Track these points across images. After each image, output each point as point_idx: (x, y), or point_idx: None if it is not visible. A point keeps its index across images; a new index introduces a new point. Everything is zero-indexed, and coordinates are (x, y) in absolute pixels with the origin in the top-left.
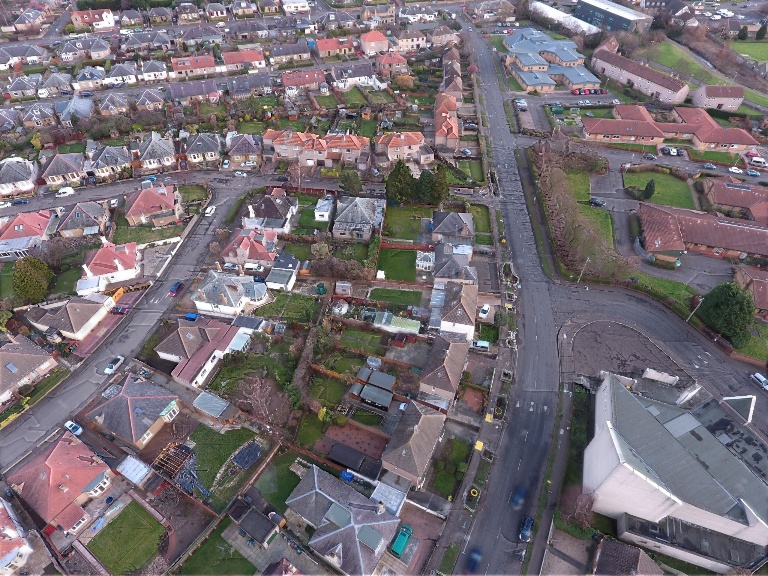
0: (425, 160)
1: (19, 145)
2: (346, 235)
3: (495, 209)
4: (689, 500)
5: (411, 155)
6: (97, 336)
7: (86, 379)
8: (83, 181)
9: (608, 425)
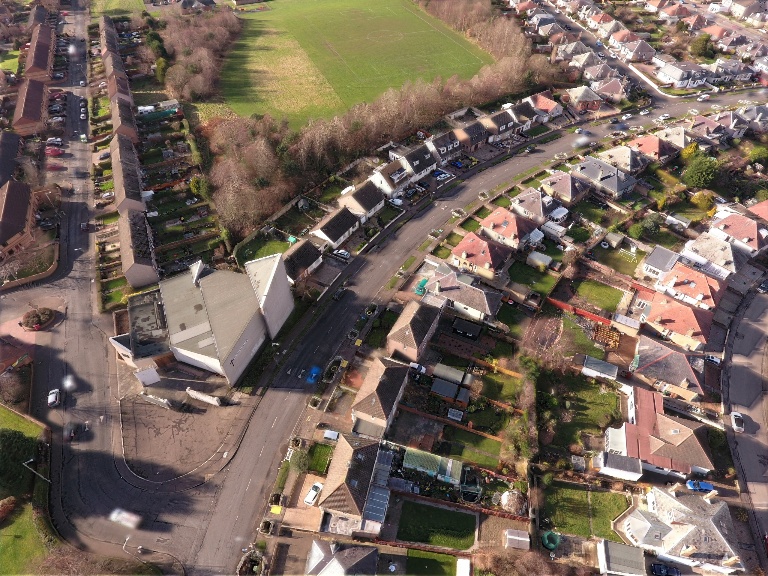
0: None
1: None
2: None
3: None
4: (234, 274)
5: None
6: None
7: (752, 409)
8: None
9: (265, 299)
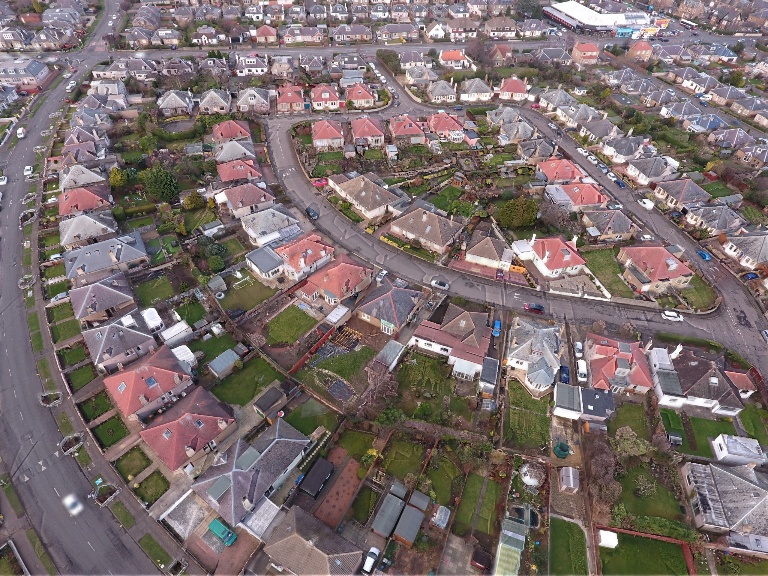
0: None
1: (698, 158)
2: (689, 486)
3: None
4: None
5: None
6: (471, 268)
7: (427, 272)
8: (672, 210)
9: None
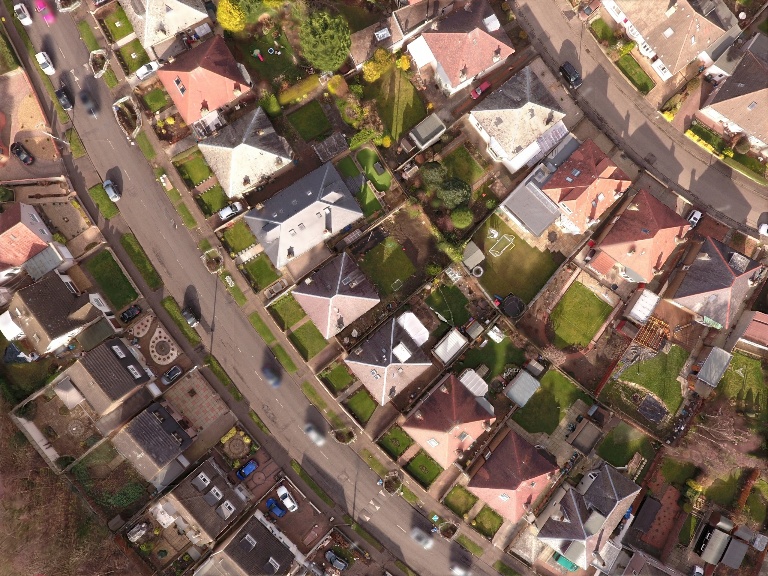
0: None
1: None
2: None
3: None
4: None
5: None
6: None
7: (753, 205)
8: None
9: None
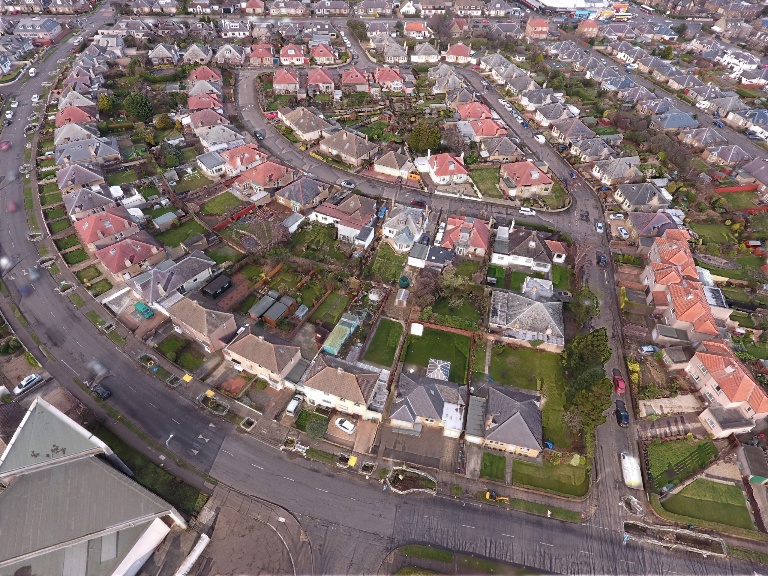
0: (707, 421)
1: (599, 108)
2: None
3: (584, 513)
4: None
5: (712, 399)
6: (377, 176)
7: (341, 177)
8: None
9: (97, 438)
